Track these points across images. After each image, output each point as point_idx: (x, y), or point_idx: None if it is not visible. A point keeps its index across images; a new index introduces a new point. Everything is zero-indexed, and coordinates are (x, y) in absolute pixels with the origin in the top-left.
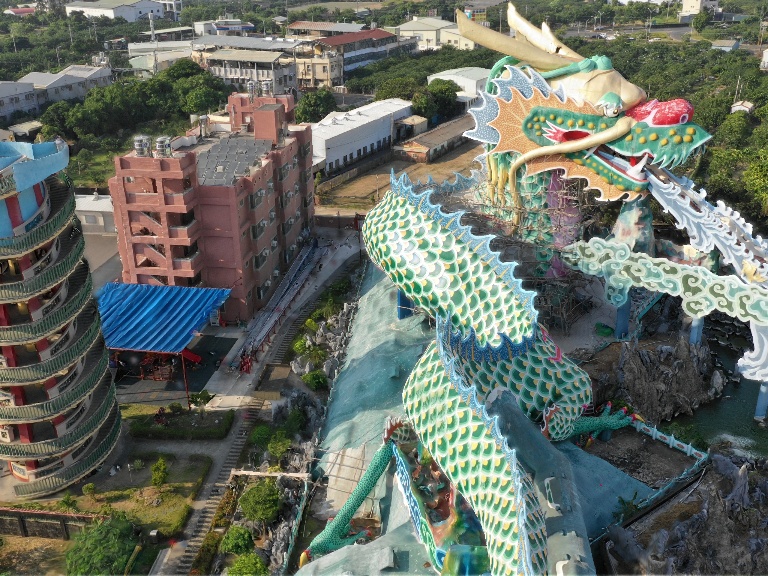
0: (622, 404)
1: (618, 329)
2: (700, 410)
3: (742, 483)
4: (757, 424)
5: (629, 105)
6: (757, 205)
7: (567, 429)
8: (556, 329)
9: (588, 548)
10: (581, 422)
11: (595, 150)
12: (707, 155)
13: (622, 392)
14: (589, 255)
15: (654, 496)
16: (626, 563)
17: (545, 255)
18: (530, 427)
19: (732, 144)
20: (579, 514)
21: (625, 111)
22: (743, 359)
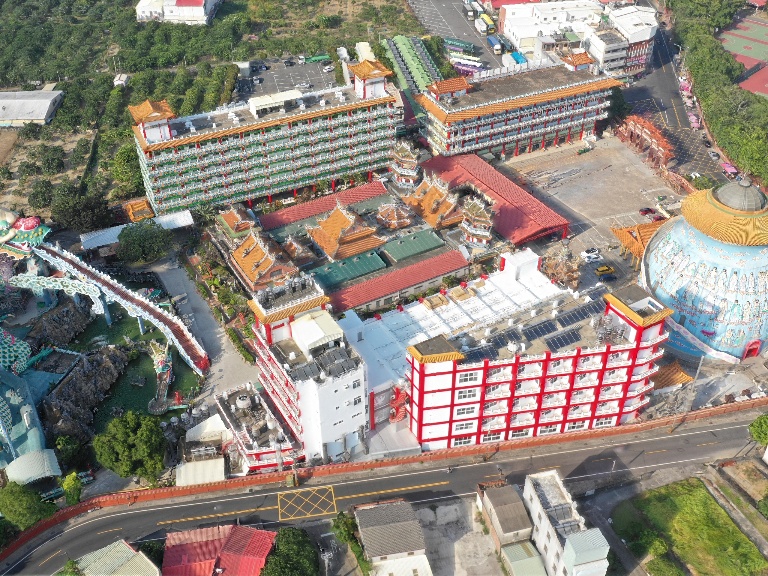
0: (49, 343)
1: (47, 303)
2: (88, 328)
3: (86, 364)
4: (109, 327)
5: (12, 223)
6: (106, 207)
7: (24, 367)
8: (19, 311)
9: (34, 407)
10: (30, 361)
11: (5, 242)
12: (98, 137)
13: (48, 339)
14: (21, 281)
15: (62, 377)
16: (49, 405)
17: (1, 285)
18: (8, 374)
19: (112, 126)
20: (30, 397)
21: (12, 226)
22: (93, 308)
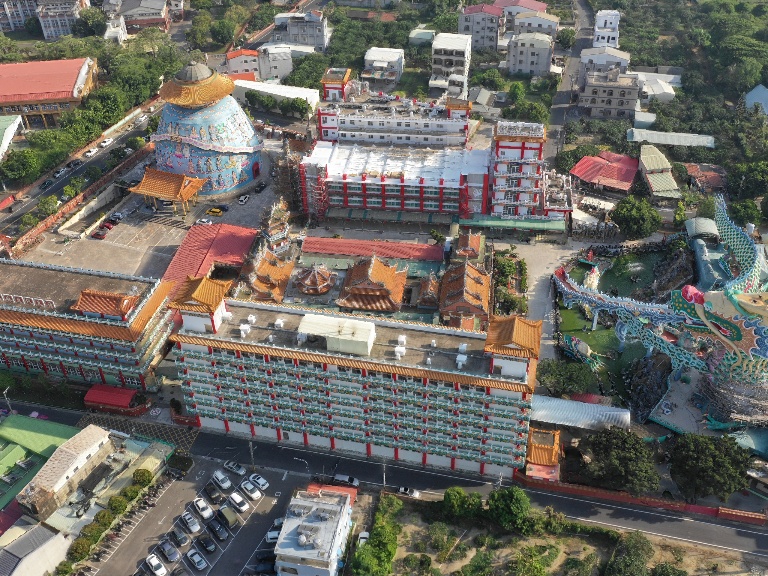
0: None
1: None
2: None
3: None
4: (623, 349)
5: None
6: None
7: None
8: None
9: None
10: None
11: None
12: None
13: None
14: None
15: None
16: None
17: None
18: None
19: None
20: None
21: None
22: None
